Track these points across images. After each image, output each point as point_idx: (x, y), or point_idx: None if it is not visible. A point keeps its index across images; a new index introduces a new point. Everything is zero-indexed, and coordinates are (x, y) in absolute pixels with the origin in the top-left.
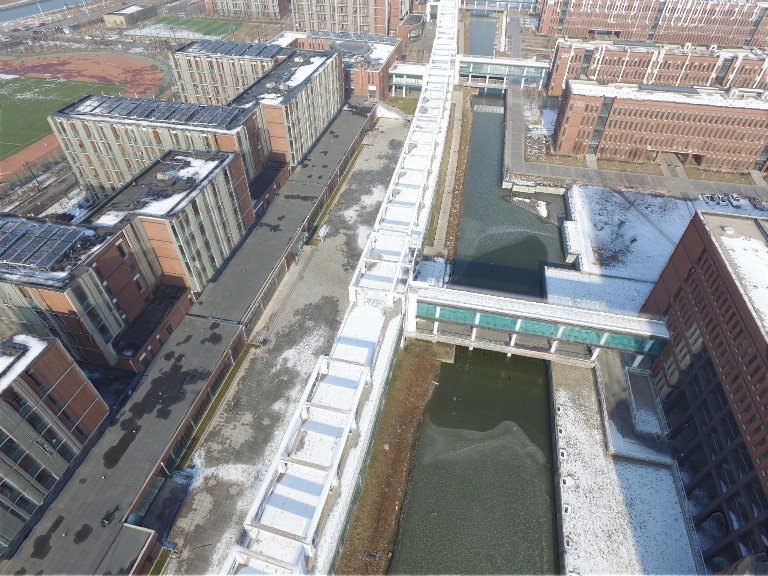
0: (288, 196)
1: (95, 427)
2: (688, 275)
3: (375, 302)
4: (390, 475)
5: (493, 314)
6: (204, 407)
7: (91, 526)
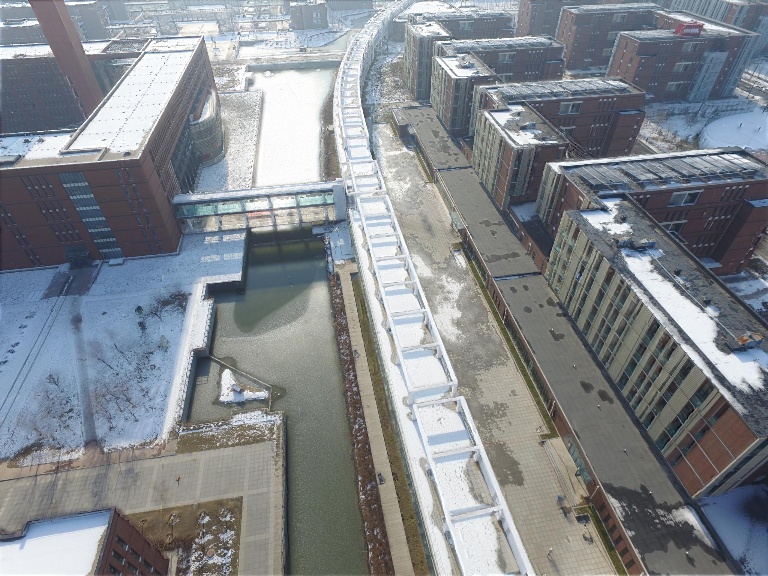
0: (516, 255)
1: None
2: None
3: (361, 174)
4: None
5: None
6: None
7: None
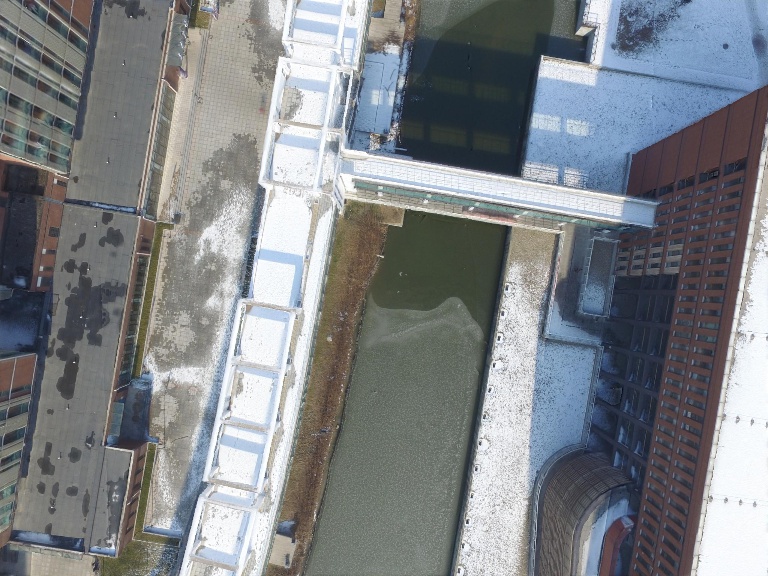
0: None
1: (32, 374)
2: (708, 172)
3: None
4: (334, 364)
5: (448, 196)
6: (135, 315)
7: (78, 449)
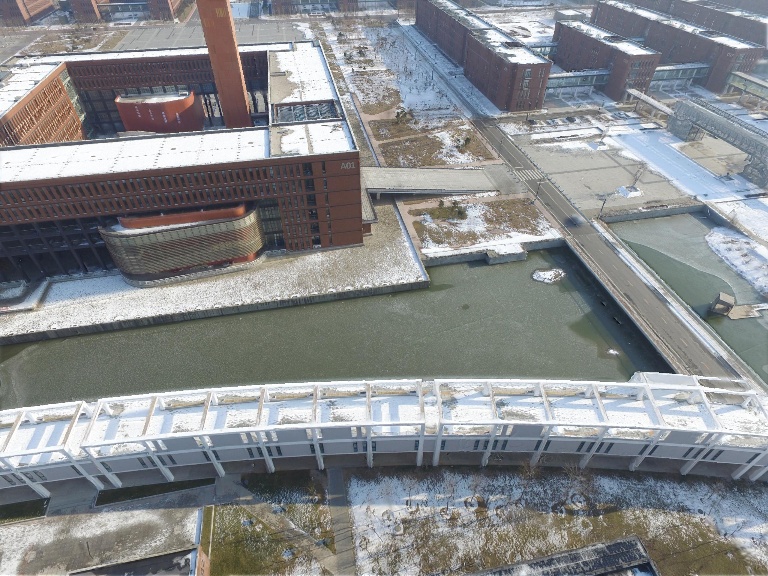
0: None
1: None
2: None
3: None
4: None
5: None
6: None
7: None
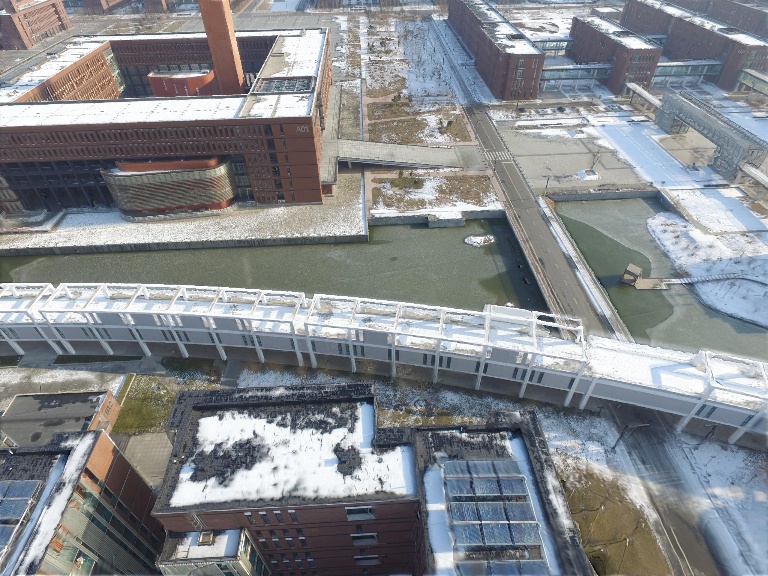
0: None
1: None
2: None
3: None
4: None
5: None
6: None
7: None
